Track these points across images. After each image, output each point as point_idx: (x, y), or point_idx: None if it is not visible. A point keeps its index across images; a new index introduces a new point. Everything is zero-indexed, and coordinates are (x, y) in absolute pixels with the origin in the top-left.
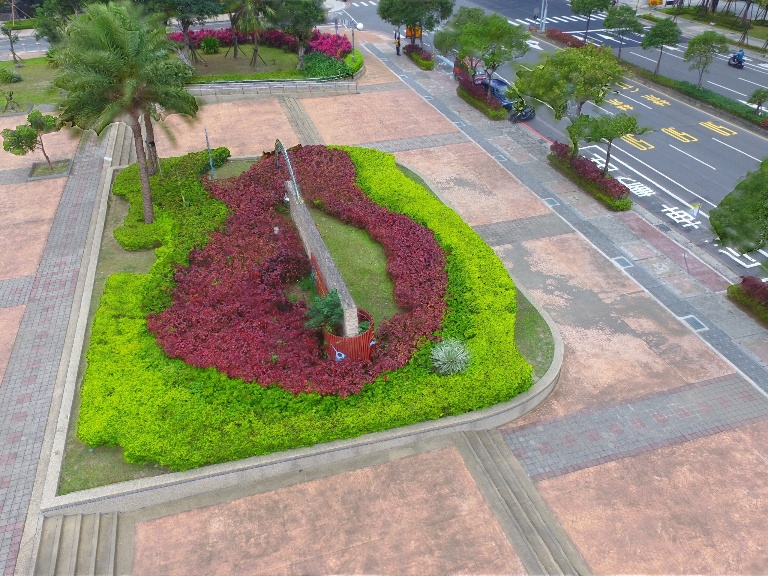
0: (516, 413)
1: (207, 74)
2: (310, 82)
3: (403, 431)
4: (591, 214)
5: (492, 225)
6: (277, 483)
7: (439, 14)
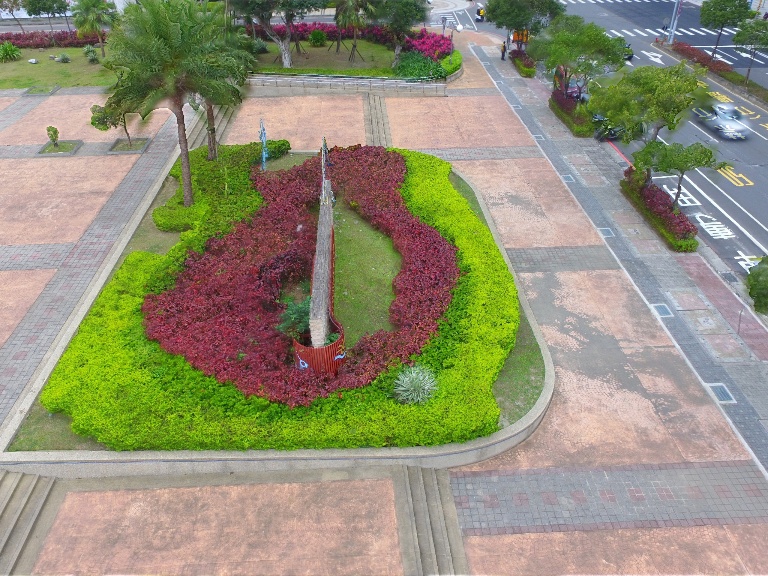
0: (472, 457)
1: (305, 66)
2: (400, 81)
3: (340, 453)
4: (647, 251)
5: (530, 249)
6: (205, 480)
7: (548, 19)
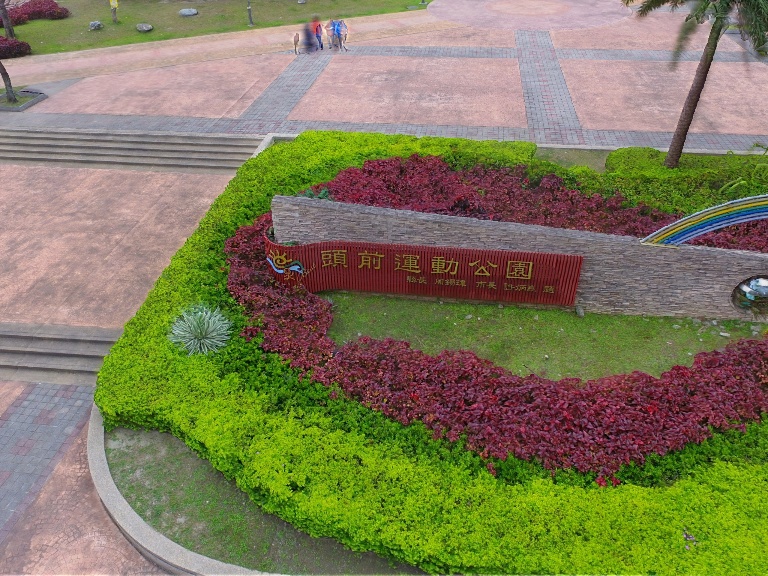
0: None
1: None
2: None
3: None
4: None
5: None
6: None
7: None
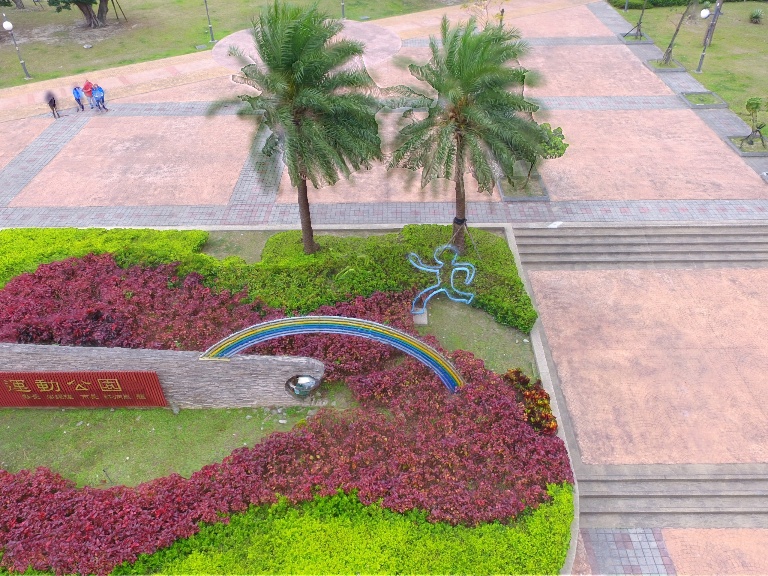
0: None
1: None
2: None
3: None
4: None
5: None
6: None
7: None
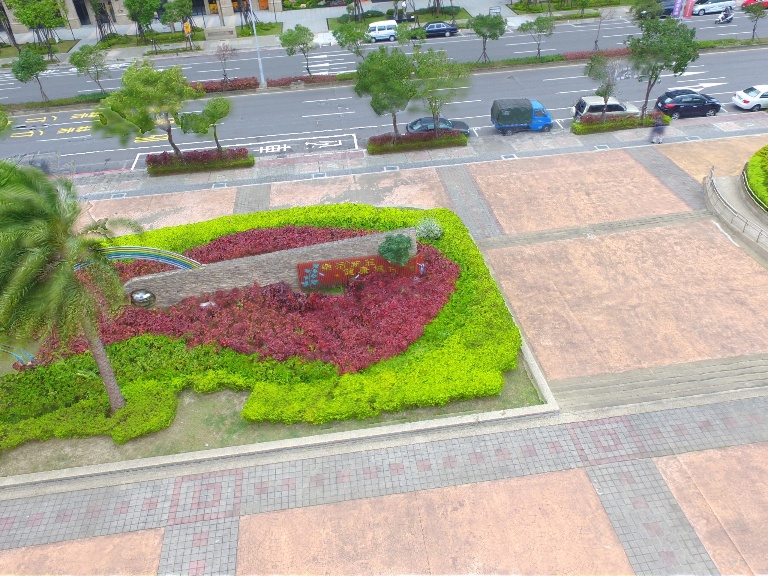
0: None
1: None
2: None
3: None
4: (251, 174)
5: (236, 214)
6: None
7: None
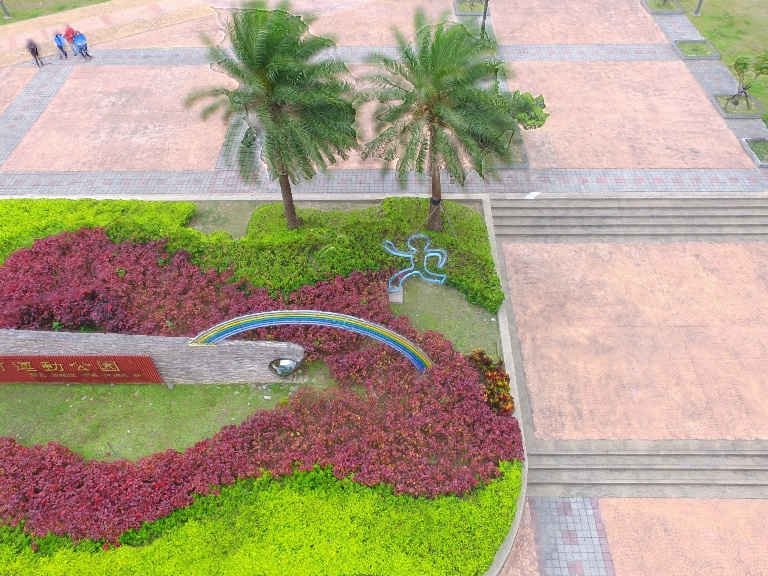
0: None
1: None
2: None
3: None
4: None
5: None
6: None
7: None
